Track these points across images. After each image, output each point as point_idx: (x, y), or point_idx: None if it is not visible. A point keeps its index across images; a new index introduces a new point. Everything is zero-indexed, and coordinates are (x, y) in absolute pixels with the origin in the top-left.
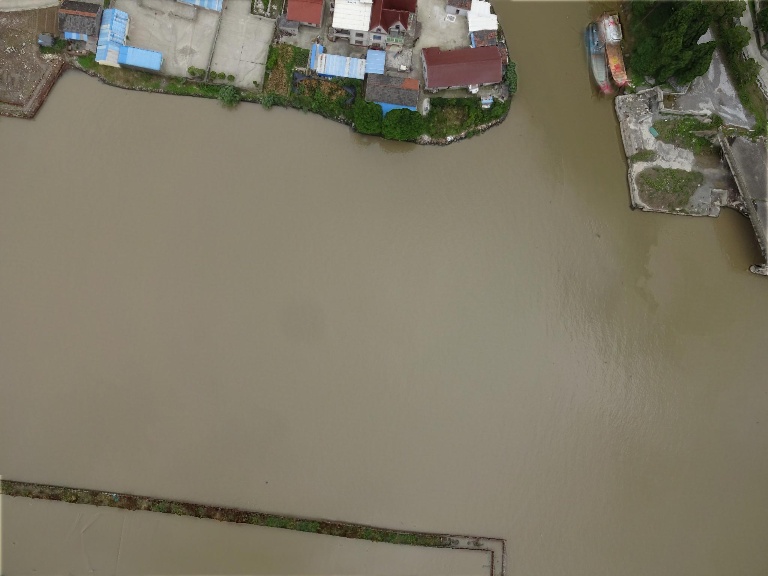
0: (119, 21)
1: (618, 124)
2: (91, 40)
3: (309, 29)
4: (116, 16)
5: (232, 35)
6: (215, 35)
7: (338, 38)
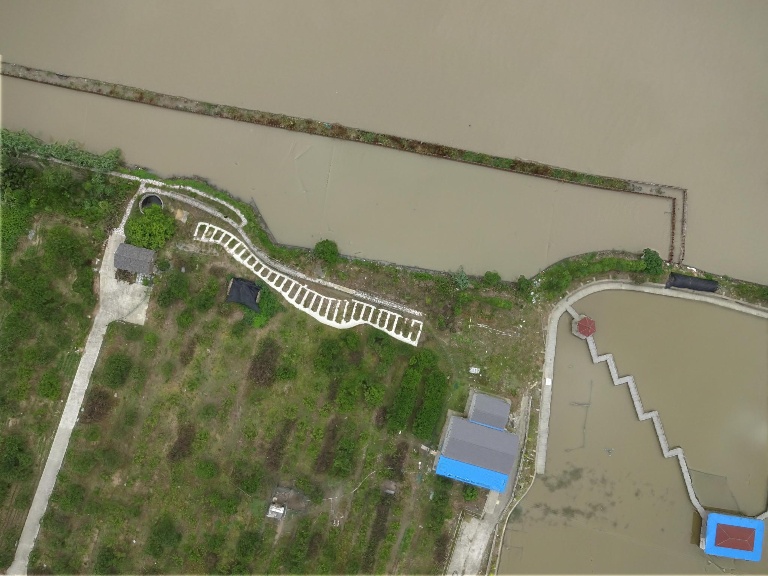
0: None
1: None
2: None
3: None
4: None
5: None
6: None
7: None
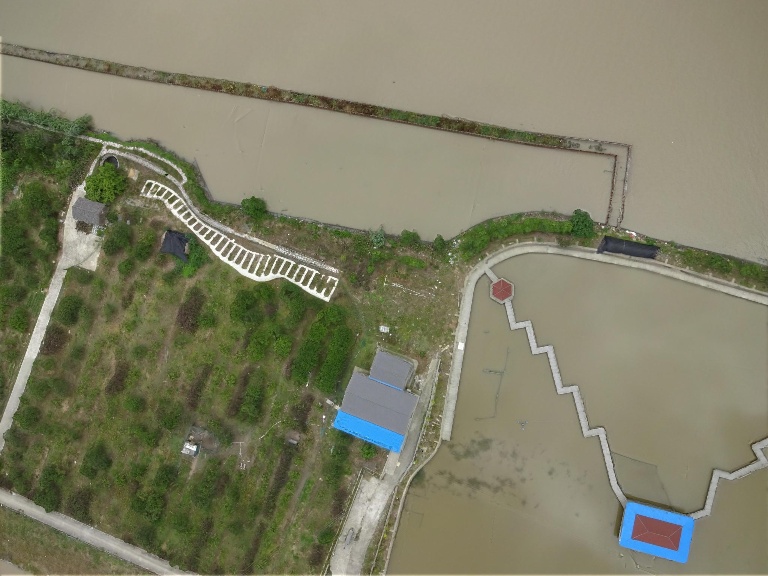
0: None
1: None
2: None
3: None
4: None
5: None
6: None
7: None
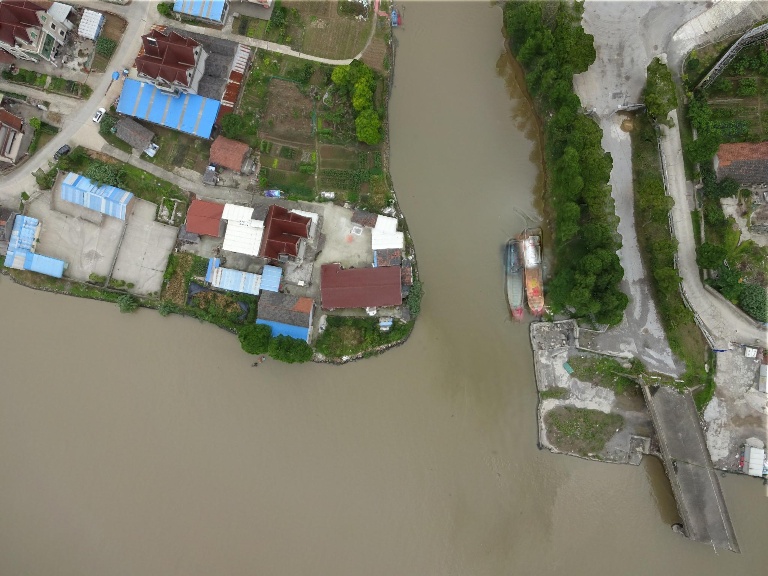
0: (28, 228)
1: (532, 352)
2: (2, 244)
3: (211, 238)
4: (25, 223)
5: (136, 241)
6: (120, 240)
7: None
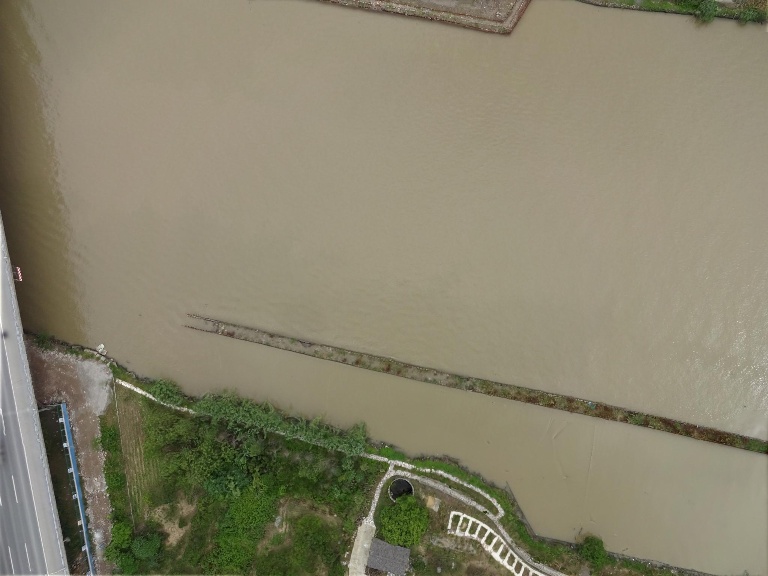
0: None
1: None
2: None
3: None
4: None
5: None
6: None
7: None
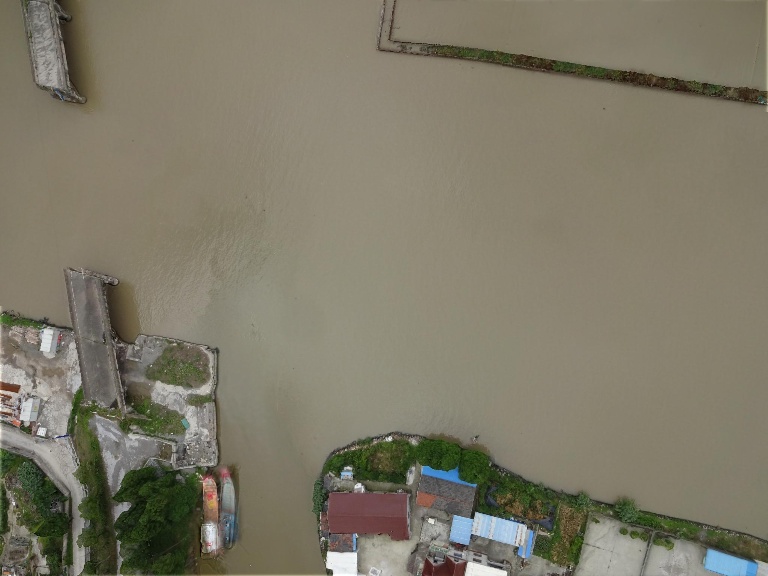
0: None
1: (218, 437)
2: None
3: None
4: None
5: None
6: None
7: (500, 564)
